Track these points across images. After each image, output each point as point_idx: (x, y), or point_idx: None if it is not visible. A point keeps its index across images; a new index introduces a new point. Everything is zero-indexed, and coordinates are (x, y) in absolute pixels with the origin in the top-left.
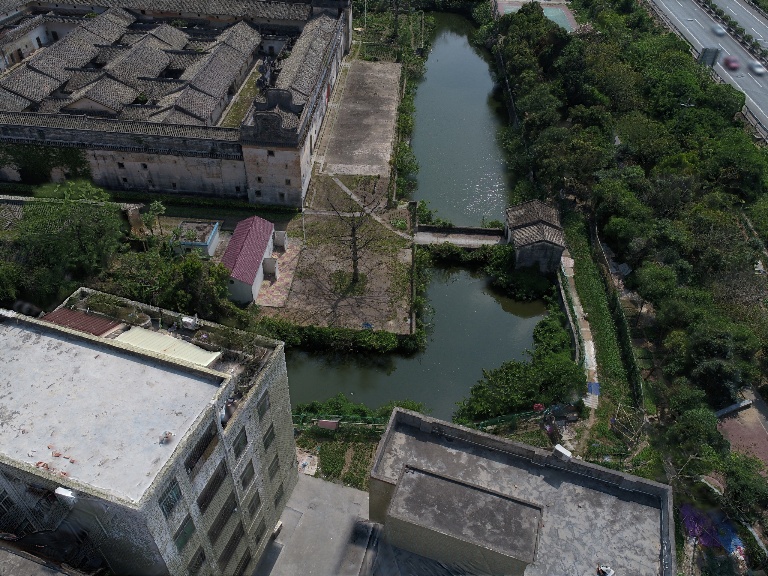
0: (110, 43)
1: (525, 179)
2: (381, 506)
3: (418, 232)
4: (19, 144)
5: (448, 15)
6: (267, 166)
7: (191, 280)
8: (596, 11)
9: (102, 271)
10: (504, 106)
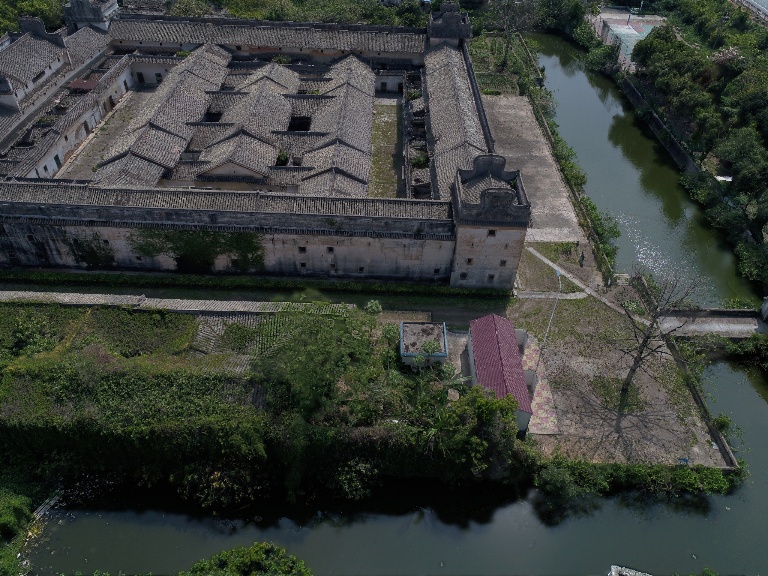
0: (218, 88)
1: (743, 240)
2: None
3: (659, 317)
4: (183, 230)
5: (540, 36)
6: (483, 247)
7: (485, 423)
8: (707, 29)
9: None
10: (660, 145)
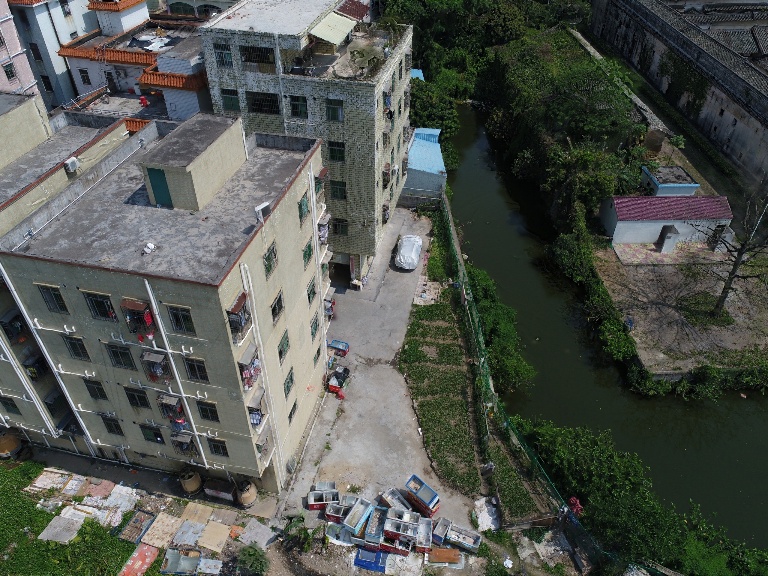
0: None
1: None
2: None
3: None
4: None
5: None
6: None
7: None
8: None
9: None
10: None
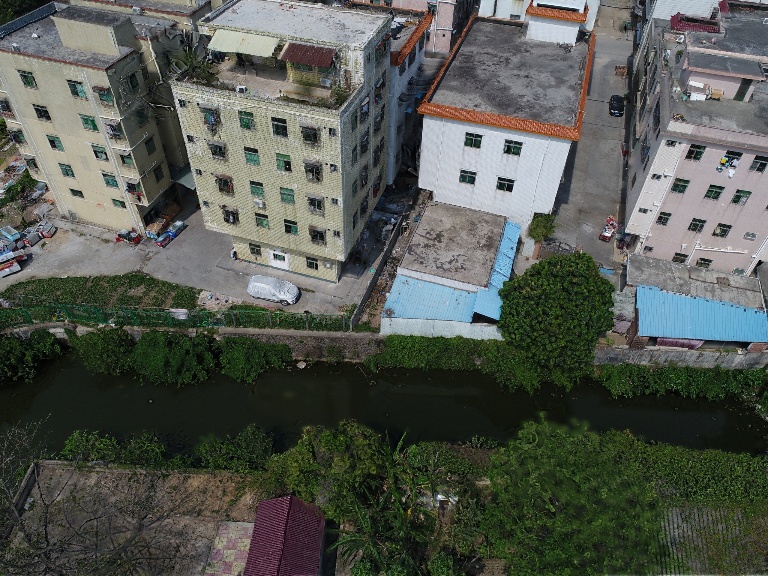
0: None
1: None
2: (134, 45)
3: None
4: None
5: None
6: None
7: None
8: None
9: None
10: None
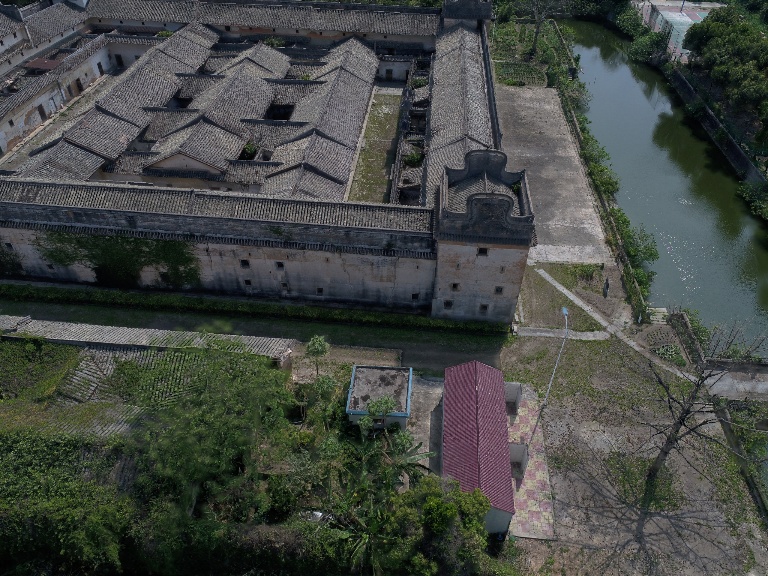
0: (194, 70)
1: None
2: None
3: (706, 370)
4: (97, 235)
5: (578, 24)
6: (472, 269)
7: (435, 534)
8: None
9: (245, 469)
10: (714, 147)
